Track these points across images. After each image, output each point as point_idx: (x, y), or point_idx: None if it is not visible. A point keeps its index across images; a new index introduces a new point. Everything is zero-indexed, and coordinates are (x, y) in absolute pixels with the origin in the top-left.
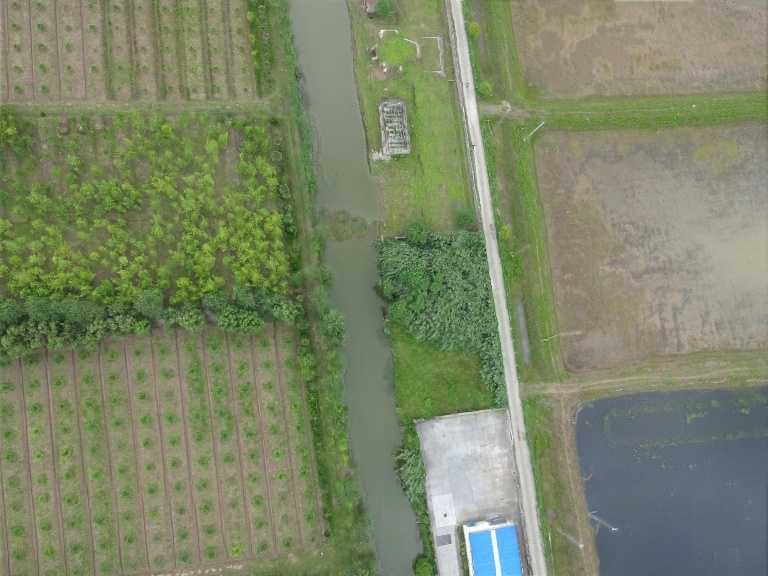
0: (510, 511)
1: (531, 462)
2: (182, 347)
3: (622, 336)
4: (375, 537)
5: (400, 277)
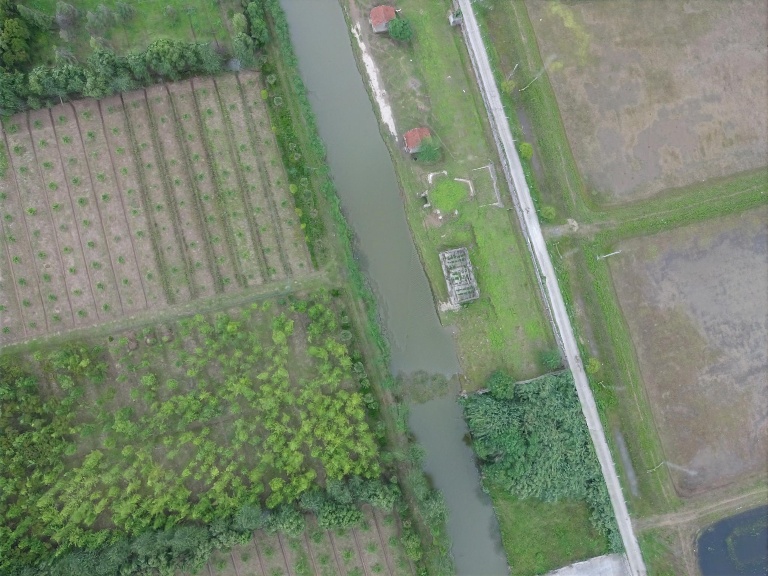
0: None
1: None
2: (285, 543)
3: (733, 448)
4: None
5: (492, 440)
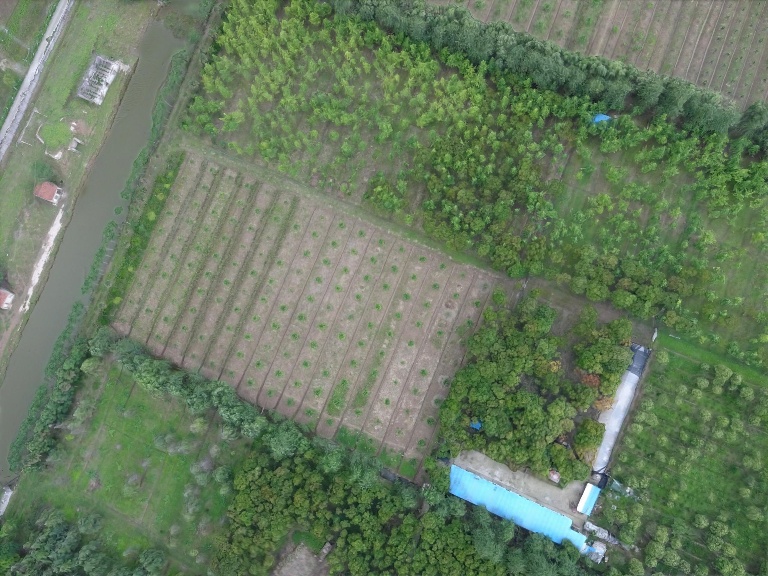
0: None
1: None
2: None
3: None
4: None
5: None
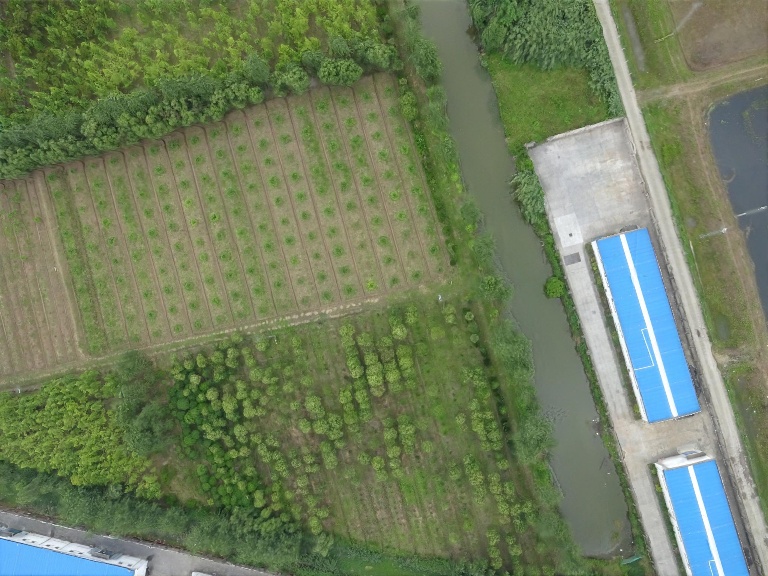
0: (642, 223)
1: (660, 170)
2: (294, 114)
3: (756, 22)
4: (498, 254)
5: None
